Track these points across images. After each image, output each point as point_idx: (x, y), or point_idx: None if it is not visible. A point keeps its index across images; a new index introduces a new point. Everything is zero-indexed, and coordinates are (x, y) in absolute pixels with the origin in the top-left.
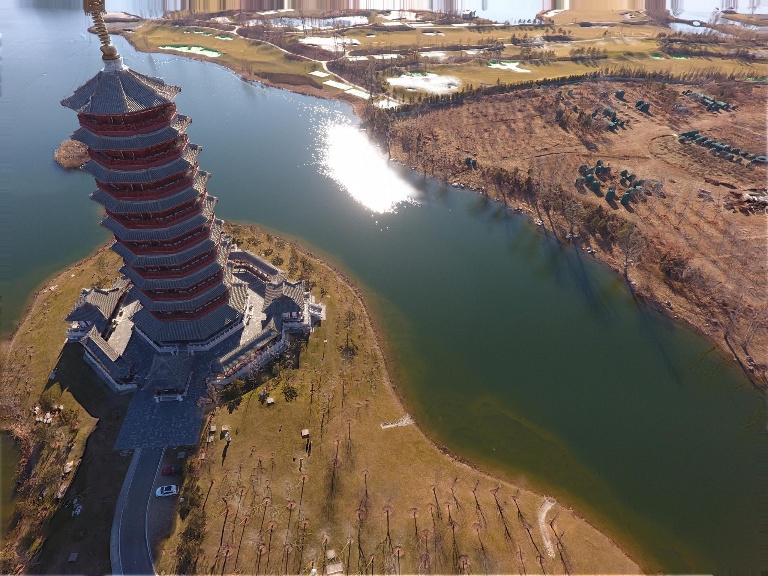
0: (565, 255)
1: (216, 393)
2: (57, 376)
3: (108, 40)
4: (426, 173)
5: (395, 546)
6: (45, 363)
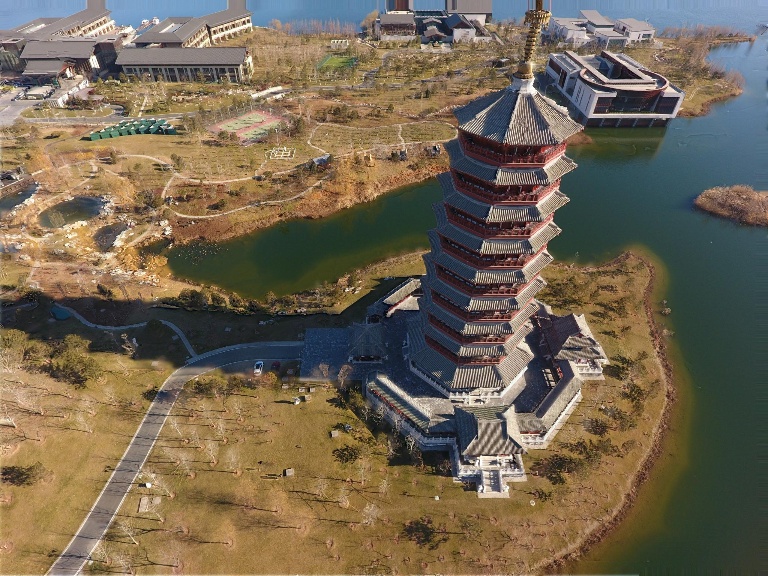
0: None
1: (340, 380)
2: (386, 281)
3: (528, 56)
4: None
5: (137, 570)
6: (401, 271)
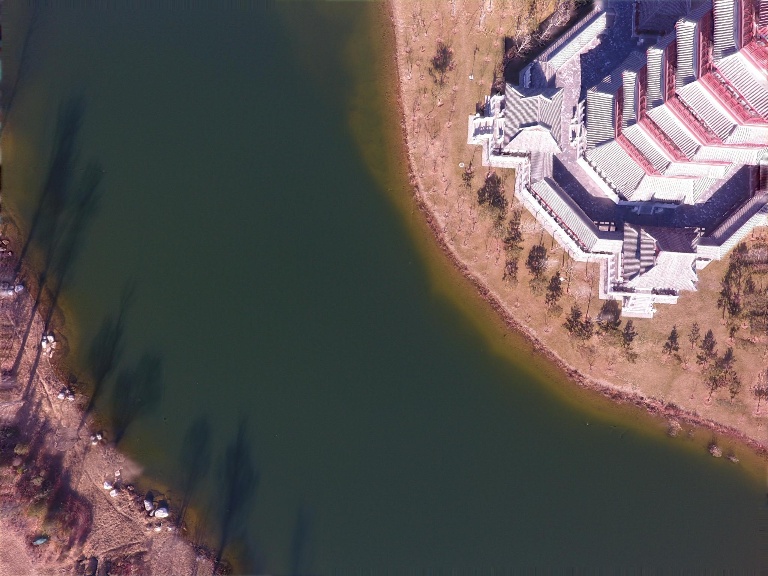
0: (53, 239)
1: None
2: None
3: None
4: (212, 575)
5: None
6: None
